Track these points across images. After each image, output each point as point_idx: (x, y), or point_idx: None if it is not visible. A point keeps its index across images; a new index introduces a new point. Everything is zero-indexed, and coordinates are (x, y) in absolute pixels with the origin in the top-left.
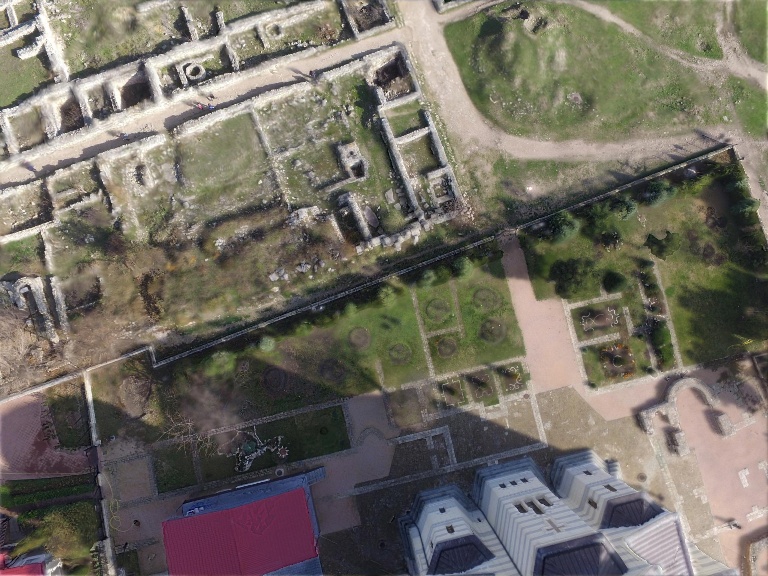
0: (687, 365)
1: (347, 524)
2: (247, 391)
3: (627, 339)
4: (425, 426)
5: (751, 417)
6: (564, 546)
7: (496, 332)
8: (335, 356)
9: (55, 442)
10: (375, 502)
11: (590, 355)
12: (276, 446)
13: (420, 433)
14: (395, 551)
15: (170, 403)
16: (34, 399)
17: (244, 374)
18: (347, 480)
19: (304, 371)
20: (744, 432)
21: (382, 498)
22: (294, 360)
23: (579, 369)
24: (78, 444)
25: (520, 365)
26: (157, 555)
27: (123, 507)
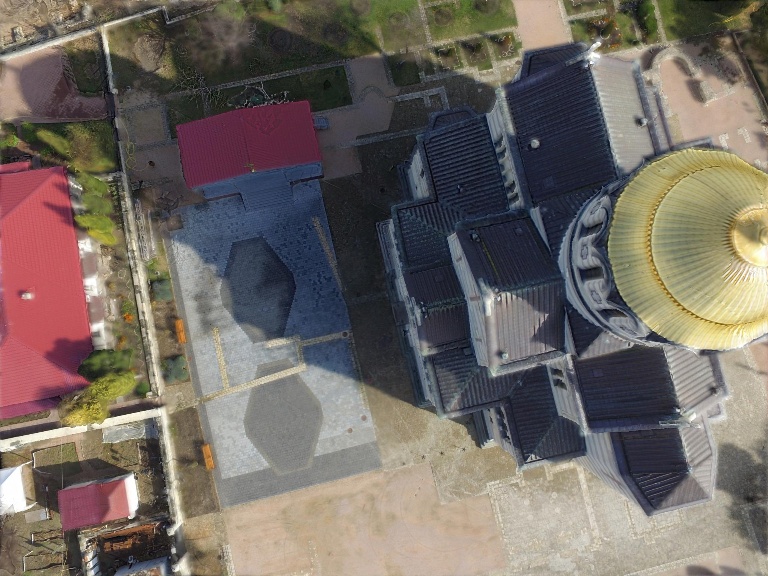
0: (670, 40)
1: (349, 171)
2: (255, 49)
3: (613, 15)
4: (422, 86)
5: (731, 88)
6: (549, 49)
7: (489, 4)
8: (337, 21)
9: (75, 86)
10: (375, 152)
11: (578, 28)
12: (282, 100)
13: (418, 93)
14: (394, 196)
15: (182, 59)
16: (54, 51)
17: (252, 34)
18: (349, 132)
19: (308, 33)
20: (724, 101)
21: (382, 149)
22: (299, 23)
23: (568, 40)
24: (96, 90)
25: (512, 34)
26: (171, 192)
27: (139, 150)
